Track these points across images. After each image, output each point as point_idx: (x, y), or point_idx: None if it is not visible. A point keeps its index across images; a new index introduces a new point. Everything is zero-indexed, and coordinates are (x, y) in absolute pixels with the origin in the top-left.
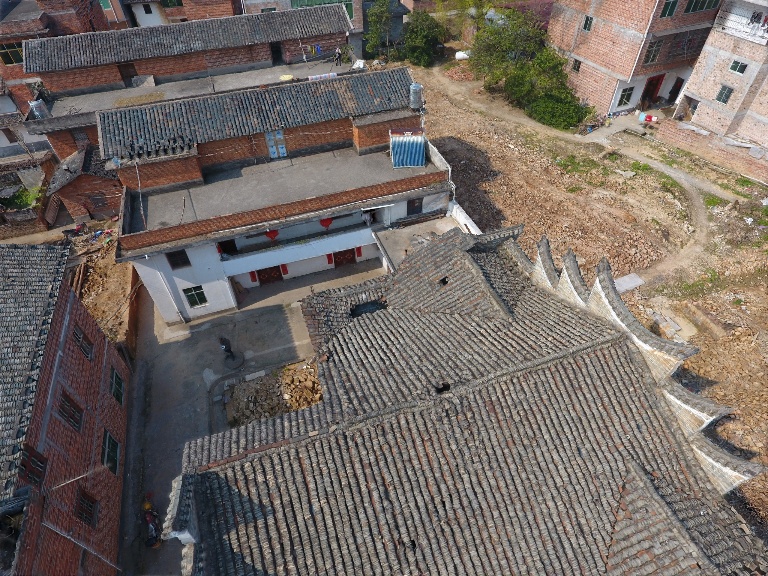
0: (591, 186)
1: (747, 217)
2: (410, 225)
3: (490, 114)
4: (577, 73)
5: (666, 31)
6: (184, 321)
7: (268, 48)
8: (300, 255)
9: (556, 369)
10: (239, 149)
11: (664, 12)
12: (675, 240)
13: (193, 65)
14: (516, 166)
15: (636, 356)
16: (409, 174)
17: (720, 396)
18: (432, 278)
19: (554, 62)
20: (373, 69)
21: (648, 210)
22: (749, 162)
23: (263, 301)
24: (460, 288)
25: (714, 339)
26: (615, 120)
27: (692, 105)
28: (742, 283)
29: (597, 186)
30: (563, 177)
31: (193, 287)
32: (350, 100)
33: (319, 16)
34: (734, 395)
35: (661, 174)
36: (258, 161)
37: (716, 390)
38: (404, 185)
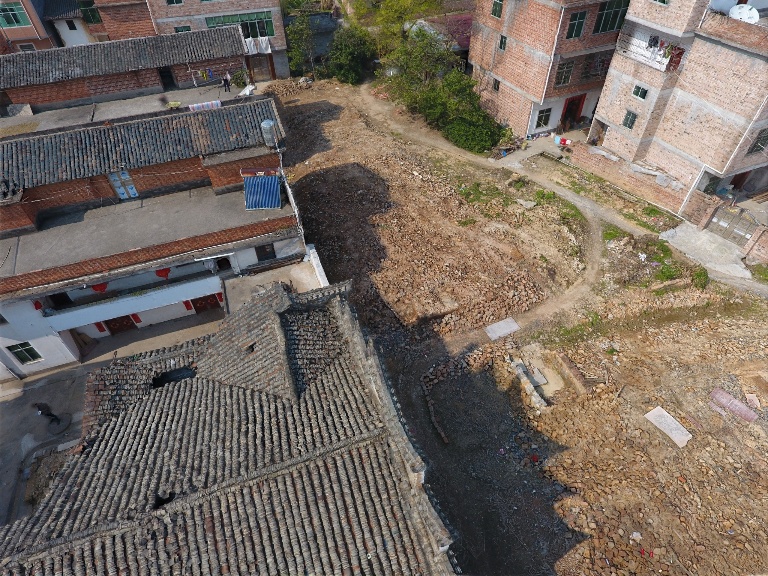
0: (486, 218)
1: (642, 253)
2: (263, 271)
3: (406, 136)
4: (497, 93)
5: (575, 52)
6: (18, 378)
7: (156, 73)
8: (140, 306)
9: (299, 475)
10: (79, 191)
11: (570, 33)
12: (561, 279)
13: (74, 92)
14: (414, 196)
15: (395, 456)
16: (261, 217)
17: (567, 464)
18: (241, 344)
19: (461, 85)
20: (298, 87)
21: (538, 246)
22: (657, 190)
23: (111, 353)
24: (262, 358)
25: (577, 395)
26: (534, 142)
27: (605, 128)
28: (625, 327)
29: (493, 218)
30: (461, 208)
31: (19, 344)
32: (203, 137)
33: (212, 39)
34: (582, 463)
35: (566, 203)
36: (105, 203)
37: (565, 457)
38: (245, 232)
